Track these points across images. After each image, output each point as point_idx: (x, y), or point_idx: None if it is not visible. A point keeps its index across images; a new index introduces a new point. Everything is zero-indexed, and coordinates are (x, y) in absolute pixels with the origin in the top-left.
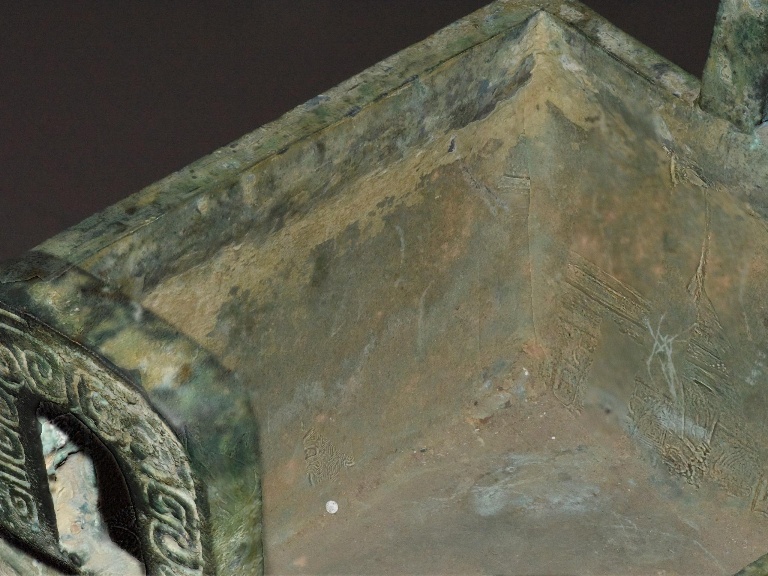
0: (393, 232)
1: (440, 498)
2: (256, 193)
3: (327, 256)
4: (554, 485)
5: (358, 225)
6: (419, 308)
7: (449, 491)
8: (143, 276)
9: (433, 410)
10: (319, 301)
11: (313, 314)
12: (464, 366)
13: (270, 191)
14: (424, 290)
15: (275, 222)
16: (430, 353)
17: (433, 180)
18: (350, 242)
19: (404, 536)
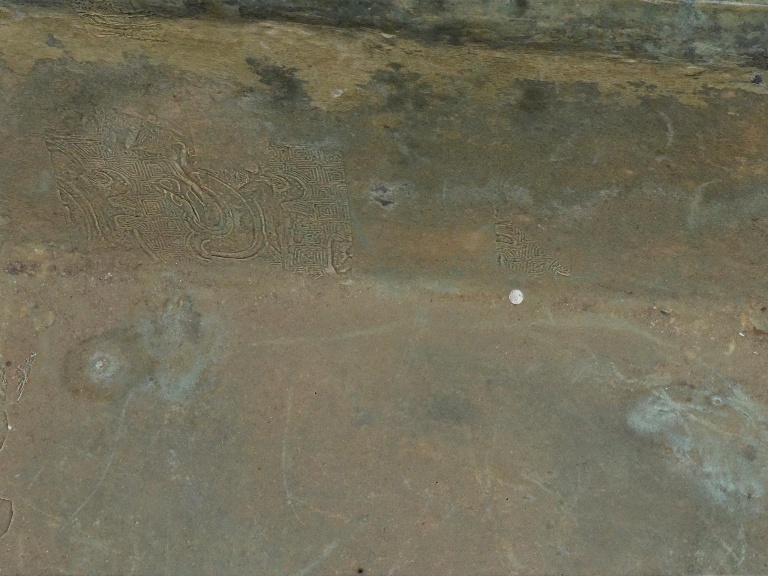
0: (655, 114)
1: (619, 372)
2: (414, 2)
3: (545, 93)
4: (729, 452)
5: (598, 86)
6: (695, 192)
7: (635, 372)
8: (237, 6)
9: (703, 284)
10: (531, 124)
11: (522, 131)
12: (765, 268)
13: (436, 9)
14: (705, 181)
15: (446, 37)
16: (708, 236)
17: (726, 96)
18: (584, 95)
19: (540, 380)
